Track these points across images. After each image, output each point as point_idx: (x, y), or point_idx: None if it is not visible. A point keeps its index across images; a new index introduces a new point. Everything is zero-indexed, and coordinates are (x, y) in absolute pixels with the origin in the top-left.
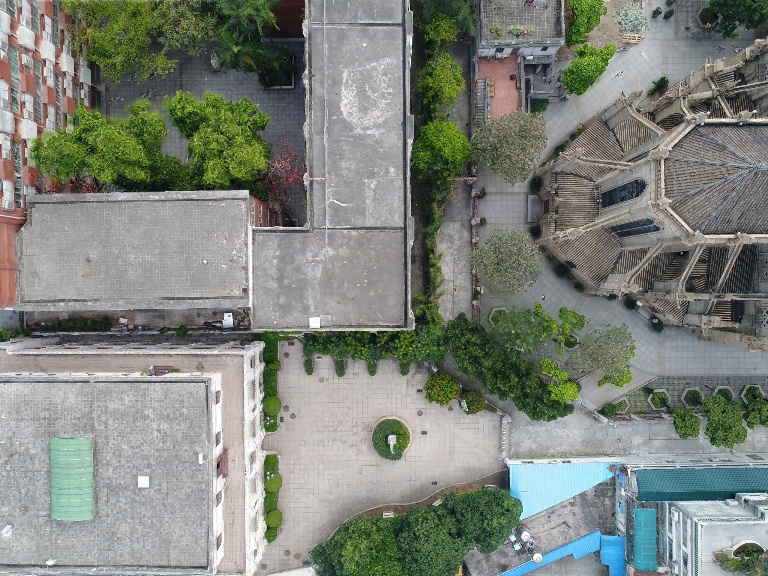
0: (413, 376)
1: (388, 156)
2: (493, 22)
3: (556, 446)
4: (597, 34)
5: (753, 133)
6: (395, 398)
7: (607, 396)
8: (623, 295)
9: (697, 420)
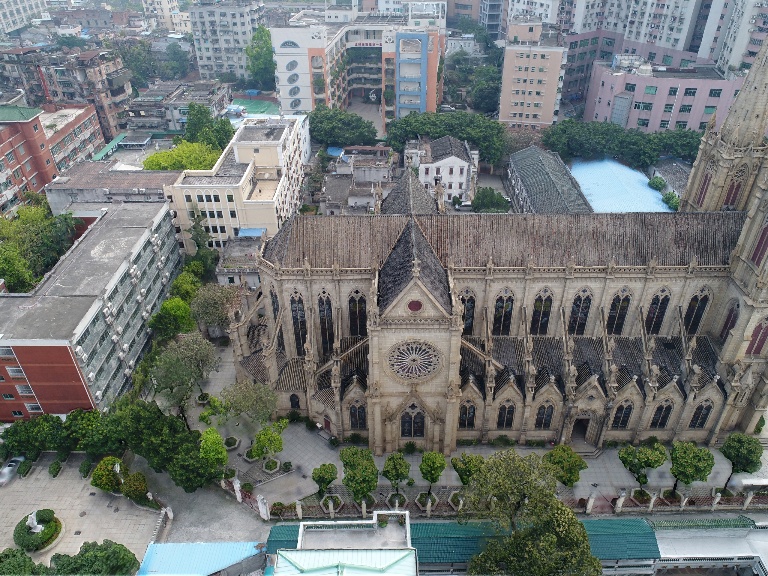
0: None
1: (108, 268)
2: None
3: None
4: None
5: None
6: (65, 500)
7: (280, 501)
8: (306, 421)
9: (332, 466)
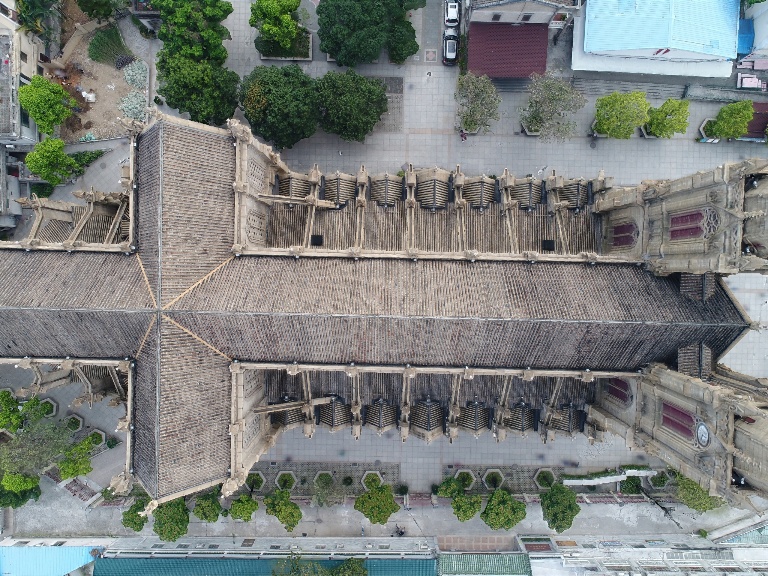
0: None
1: None
2: None
3: (61, 526)
4: (101, 120)
5: (32, 261)
6: None
7: None
8: None
9: None
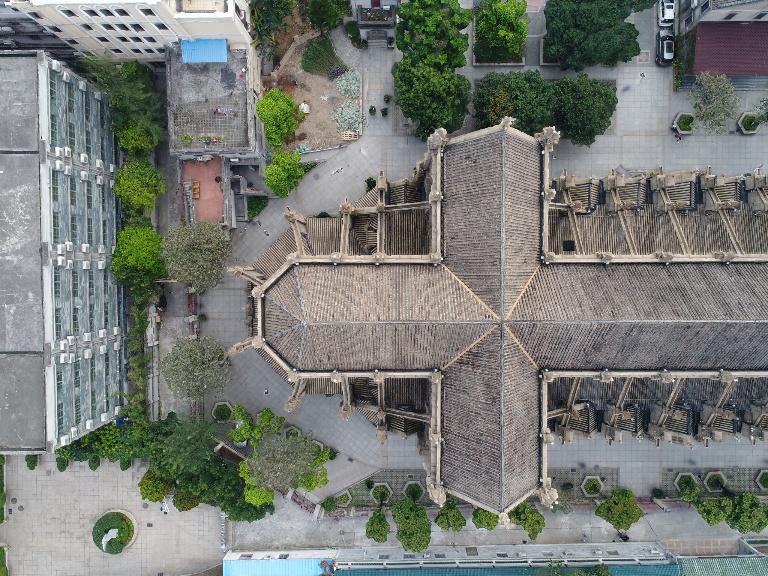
0: (138, 469)
1: (27, 282)
2: (184, 130)
3: (280, 538)
4: (315, 131)
5: (343, 275)
6: (121, 491)
7: (330, 489)
8: None
9: (385, 525)
